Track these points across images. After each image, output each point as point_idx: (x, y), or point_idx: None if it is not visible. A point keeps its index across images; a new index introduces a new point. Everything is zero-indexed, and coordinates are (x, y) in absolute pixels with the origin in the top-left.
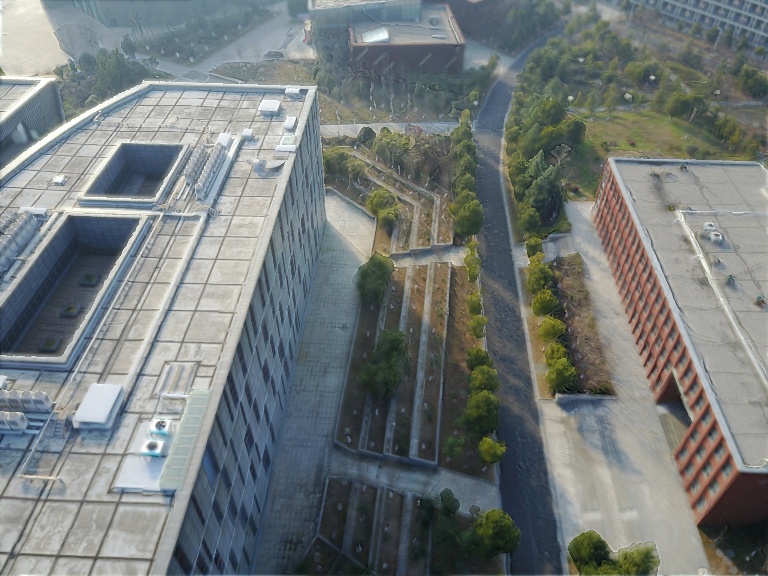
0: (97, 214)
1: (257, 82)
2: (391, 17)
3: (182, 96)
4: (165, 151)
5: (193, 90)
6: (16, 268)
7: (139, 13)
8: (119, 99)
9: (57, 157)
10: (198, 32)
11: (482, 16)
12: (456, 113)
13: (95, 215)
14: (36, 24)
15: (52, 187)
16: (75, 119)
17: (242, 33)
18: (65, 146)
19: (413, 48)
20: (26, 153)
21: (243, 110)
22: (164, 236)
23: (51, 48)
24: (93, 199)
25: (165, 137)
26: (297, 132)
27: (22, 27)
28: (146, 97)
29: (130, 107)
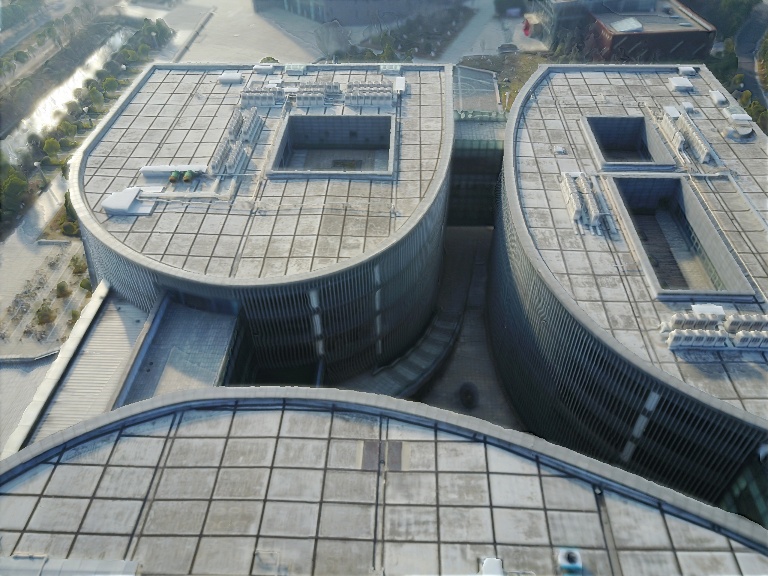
0: (638, 176)
1: (510, 73)
2: (628, 8)
3: (584, 76)
4: (622, 123)
5: (588, 71)
6: (612, 222)
7: (359, 12)
8: (536, 80)
9: (533, 131)
10: (418, 29)
11: (701, 6)
12: (737, 94)
13: (637, 176)
14: (256, 26)
15: (559, 156)
16: (518, 98)
17: (459, 29)
18: (529, 121)
19: (668, 36)
20: (510, 127)
21: (653, 87)
22: (708, 193)
23: (289, 47)
24: (618, 164)
25: (611, 111)
26: (733, 104)
27: (246, 29)
28: (551, 78)
29: (547, 87)
